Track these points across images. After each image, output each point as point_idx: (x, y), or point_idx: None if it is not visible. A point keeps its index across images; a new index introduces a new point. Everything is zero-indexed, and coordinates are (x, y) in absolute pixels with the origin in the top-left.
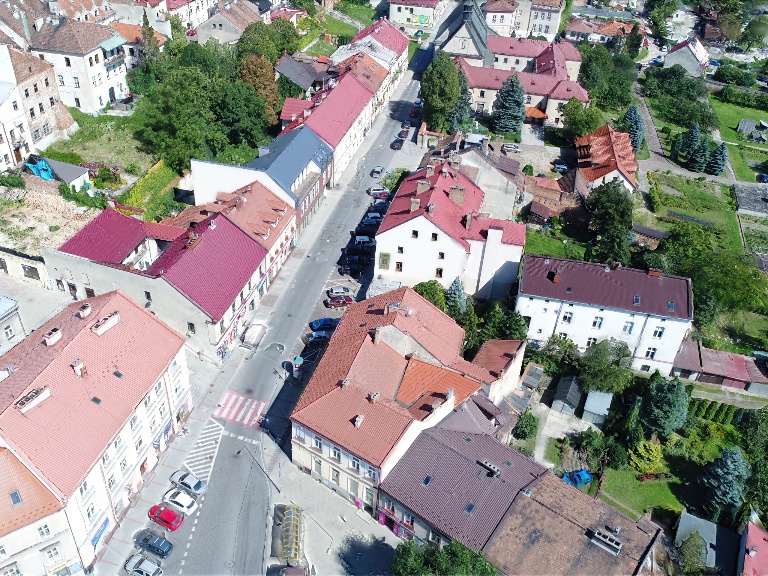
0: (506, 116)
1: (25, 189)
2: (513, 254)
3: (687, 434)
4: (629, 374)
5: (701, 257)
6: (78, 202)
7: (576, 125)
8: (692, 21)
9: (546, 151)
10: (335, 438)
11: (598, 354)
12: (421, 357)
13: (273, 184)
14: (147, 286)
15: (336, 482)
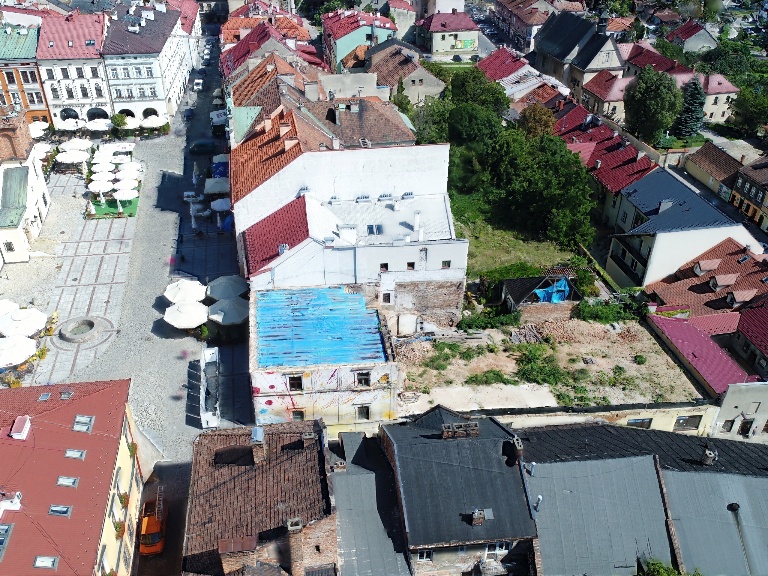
0: (693, 120)
1: (520, 324)
2: None
3: None
4: None
5: None
6: (599, 320)
7: (762, 114)
8: (652, 8)
9: (739, 145)
10: None
11: None
12: None
13: (747, 236)
14: None
15: None
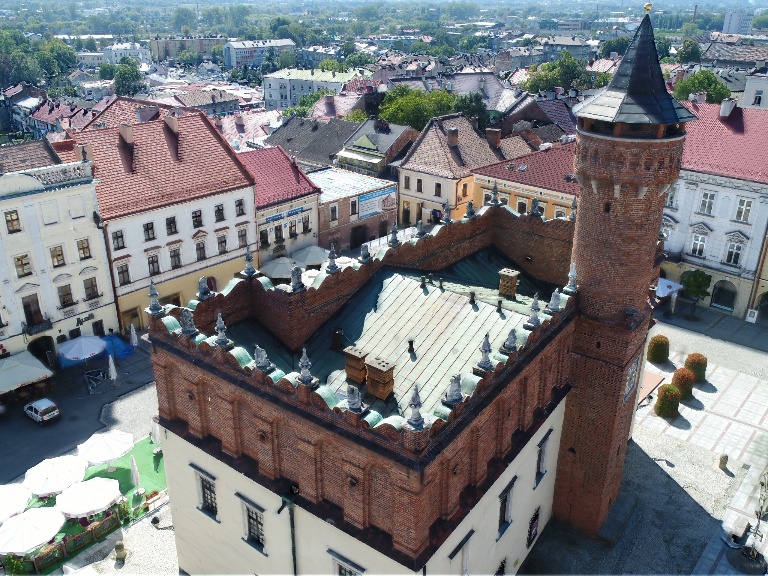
0: None
1: None
2: None
3: None
4: None
5: None
6: None
7: None
8: None
9: None
10: None
11: None
12: None
13: None
14: None
15: None
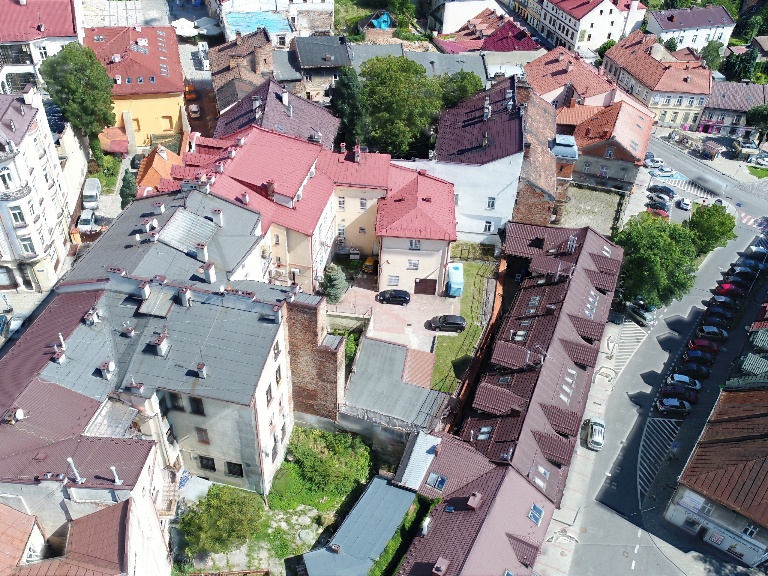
0: None
1: None
2: (640, 16)
3: (753, 78)
4: (722, 57)
5: (704, 2)
6: (408, 40)
7: None
8: None
9: None
10: (682, 90)
11: (713, 48)
12: (667, 59)
13: (498, 8)
14: (530, 58)
15: (673, 121)
